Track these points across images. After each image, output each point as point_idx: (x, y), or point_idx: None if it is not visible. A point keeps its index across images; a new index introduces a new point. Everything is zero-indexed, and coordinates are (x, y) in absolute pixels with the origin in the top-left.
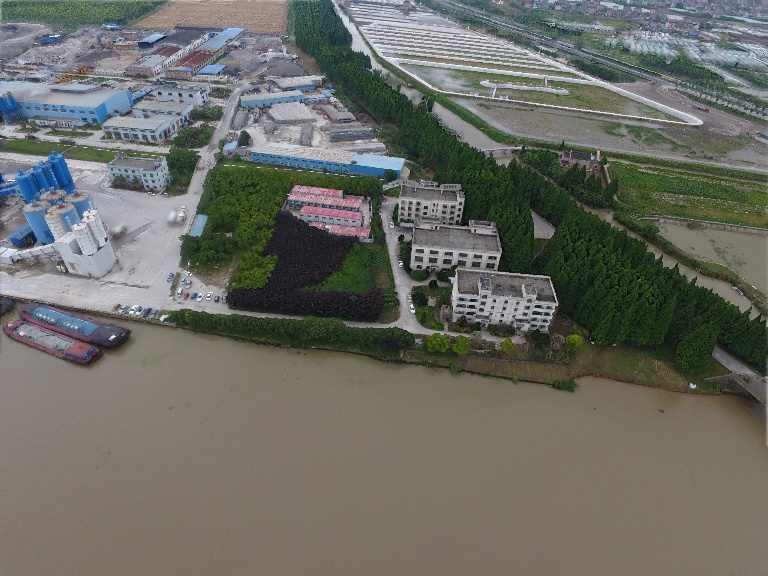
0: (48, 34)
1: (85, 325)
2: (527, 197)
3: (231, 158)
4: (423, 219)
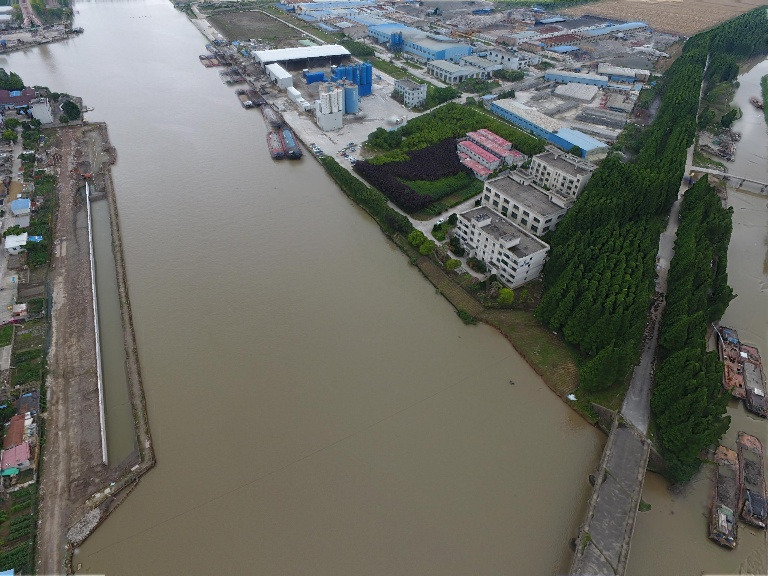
0: None
1: (290, 143)
2: (683, 216)
3: None
4: (520, 172)
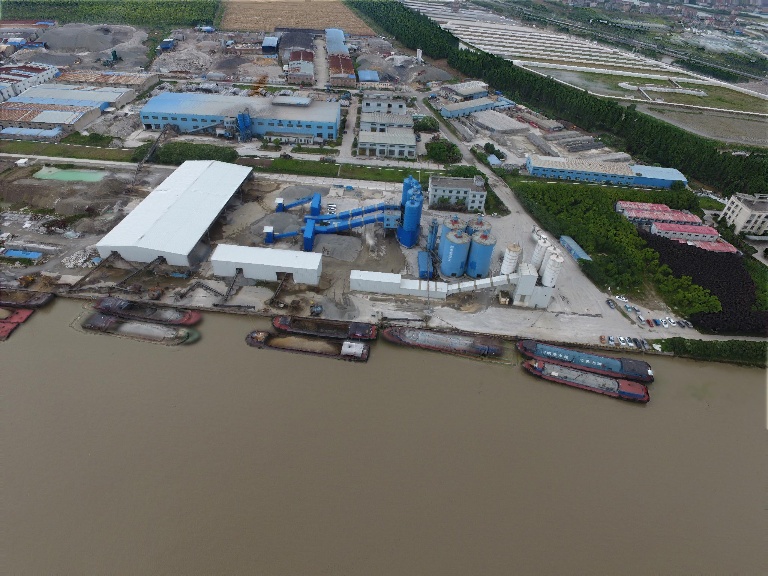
0: (148, 37)
1: (607, 361)
2: None
3: (507, 173)
4: None
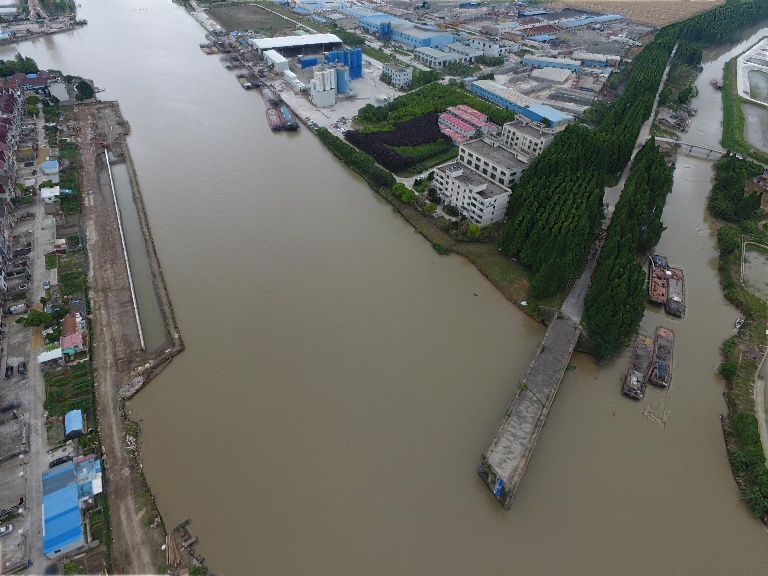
0: None
1: (288, 117)
2: None
3: None
4: None
